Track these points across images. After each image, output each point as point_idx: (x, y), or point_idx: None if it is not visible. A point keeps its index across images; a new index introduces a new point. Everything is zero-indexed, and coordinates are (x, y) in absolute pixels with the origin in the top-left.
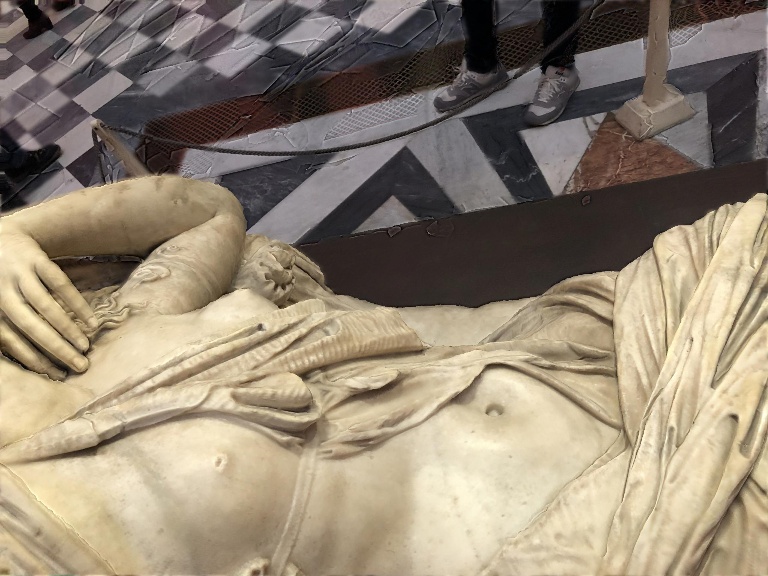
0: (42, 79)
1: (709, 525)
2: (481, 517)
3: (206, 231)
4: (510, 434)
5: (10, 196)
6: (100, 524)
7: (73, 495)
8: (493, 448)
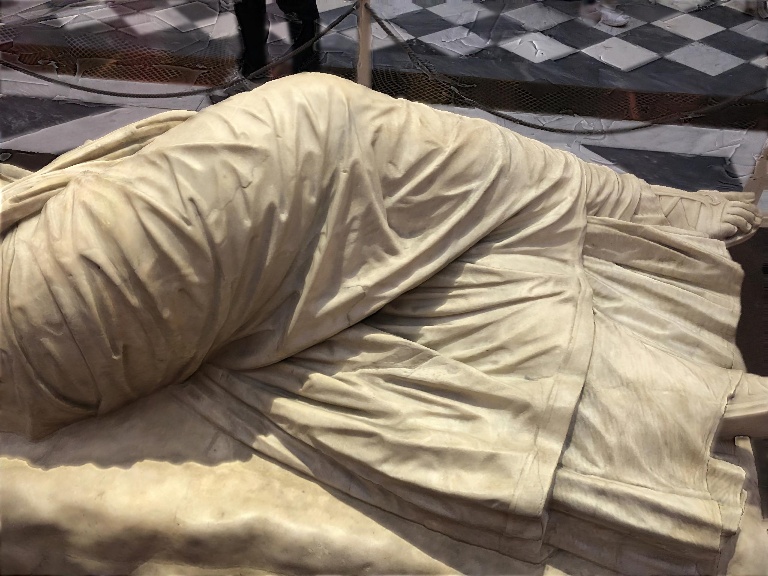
0: None
1: None
2: None
3: None
4: None
5: None
6: None
7: None
8: None
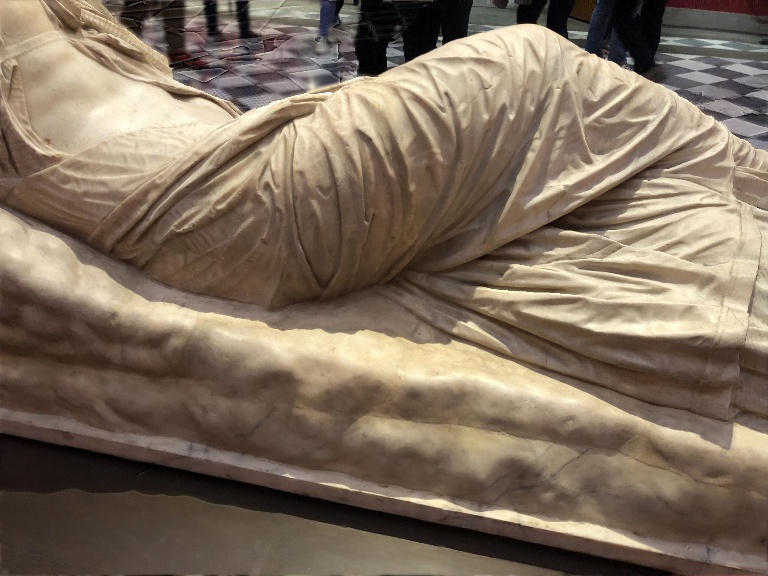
0: None
1: (255, 123)
2: (144, 120)
3: None
4: (189, 104)
5: None
6: None
7: None
8: (174, 104)
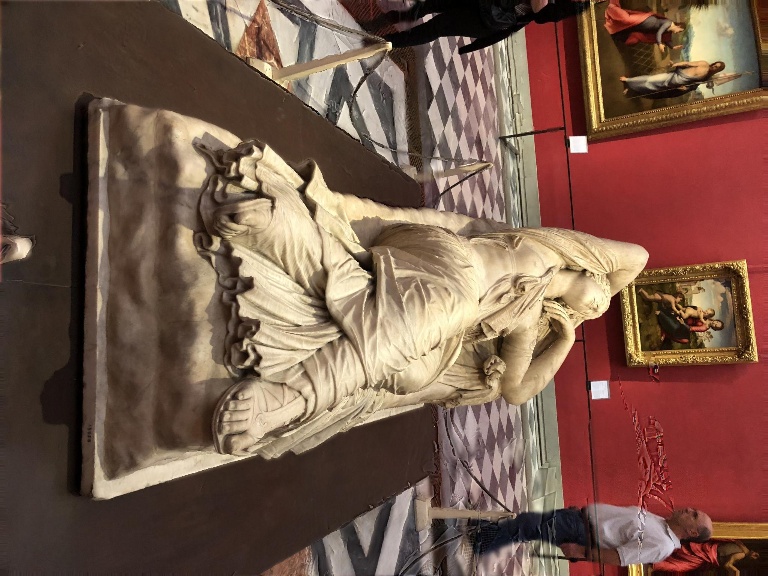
0: (552, 506)
1: None
2: None
3: (522, 374)
4: None
5: (525, 449)
6: (546, 252)
7: (551, 257)
8: None
